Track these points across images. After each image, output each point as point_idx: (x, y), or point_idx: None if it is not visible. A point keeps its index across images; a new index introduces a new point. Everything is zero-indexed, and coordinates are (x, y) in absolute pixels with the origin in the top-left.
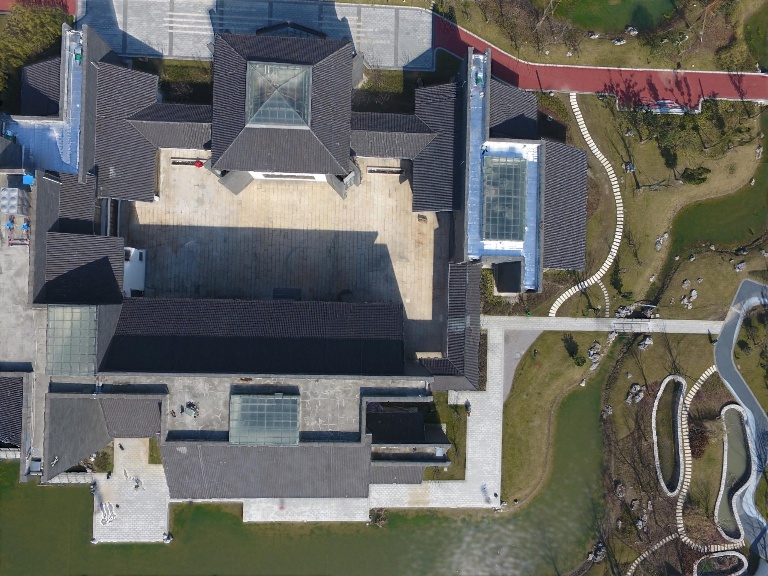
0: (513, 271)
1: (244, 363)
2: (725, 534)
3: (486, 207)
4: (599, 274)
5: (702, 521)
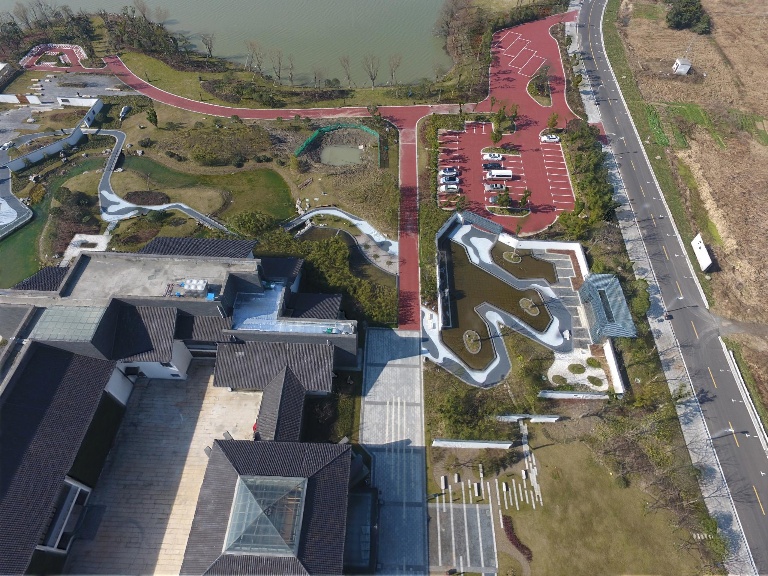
0: None
1: None
2: None
3: None
4: None
5: None
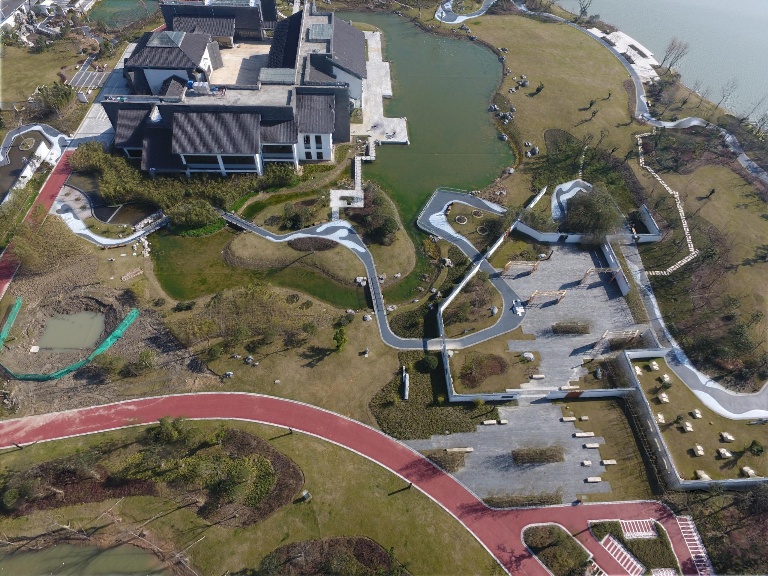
0: (266, 7)
1: None
2: None
3: (234, 3)
4: None
5: None
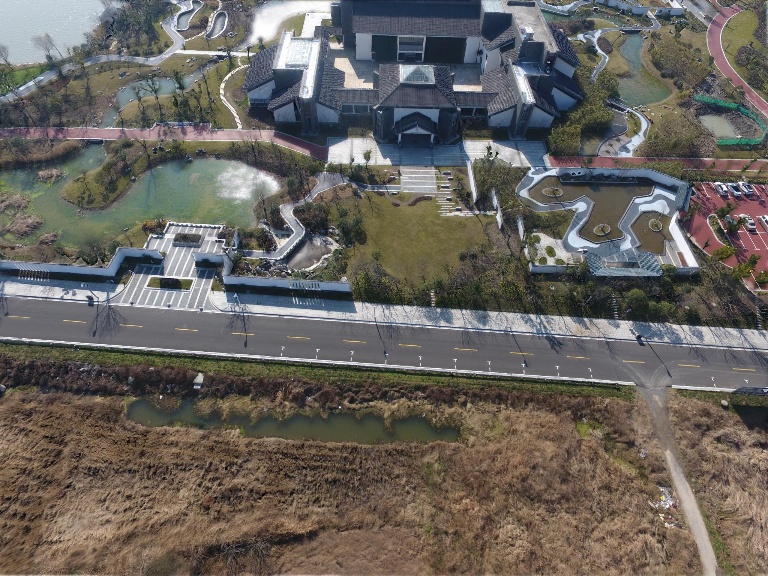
0: None
1: (422, 7)
2: (199, 1)
3: None
4: (241, 68)
5: None
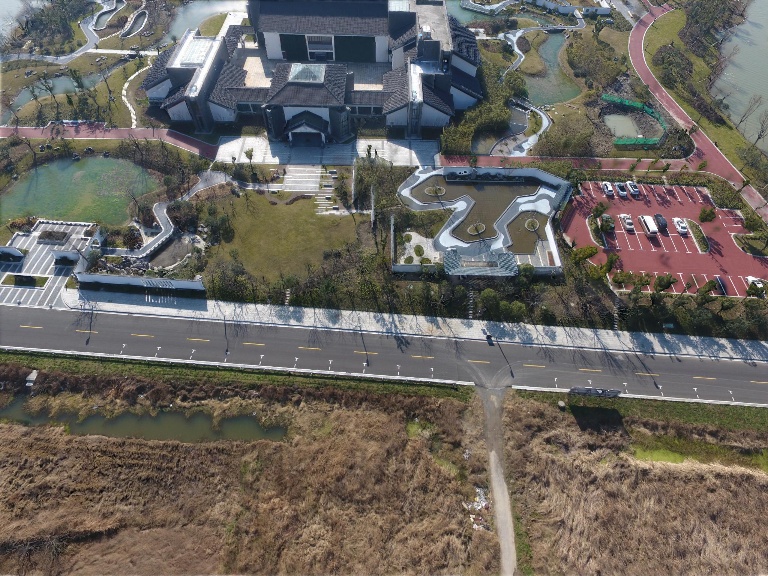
0: None
1: (330, 6)
2: (124, 1)
3: (207, 49)
4: (149, 67)
5: (133, 2)
